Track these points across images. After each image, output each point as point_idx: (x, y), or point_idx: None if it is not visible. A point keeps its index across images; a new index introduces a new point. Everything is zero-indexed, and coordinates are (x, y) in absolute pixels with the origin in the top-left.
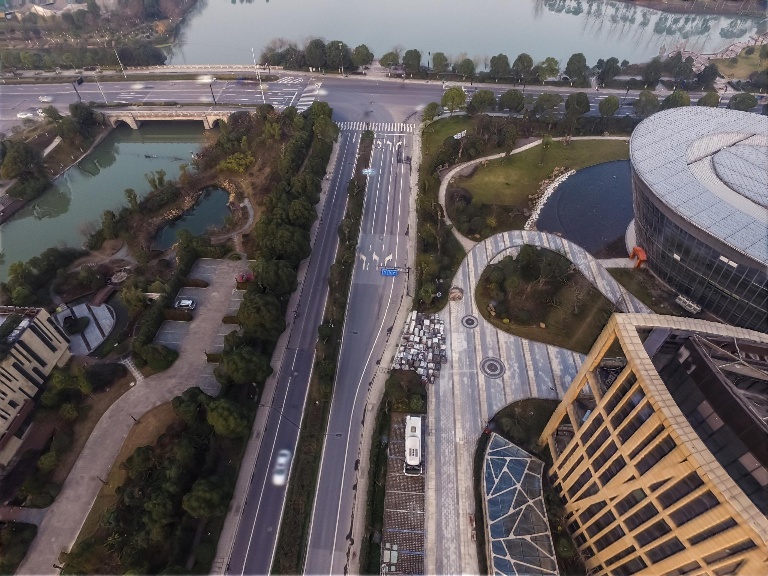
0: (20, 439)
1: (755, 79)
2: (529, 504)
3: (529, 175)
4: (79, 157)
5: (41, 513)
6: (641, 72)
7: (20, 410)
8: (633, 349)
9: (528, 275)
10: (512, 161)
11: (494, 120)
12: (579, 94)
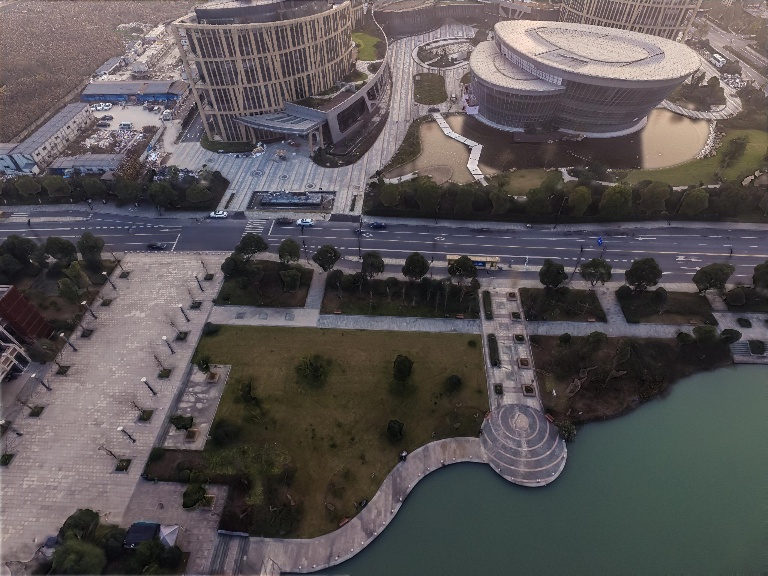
0: None
1: None
2: None
3: None
4: None
5: None
6: None
7: None
8: None
9: None
10: (758, 160)
11: None
12: None
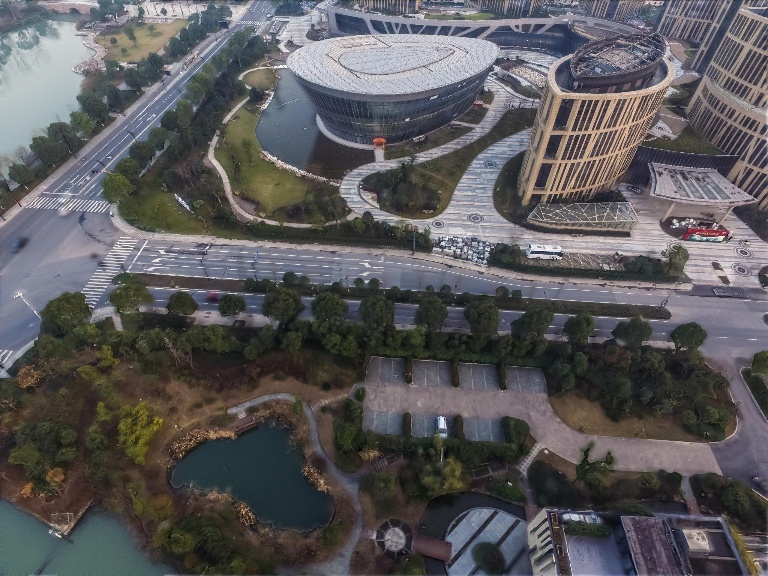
0: None
1: (171, 51)
2: (566, 208)
3: (266, 172)
4: None
5: None
6: (130, 84)
7: None
8: (576, 95)
9: (395, 190)
10: (241, 177)
11: (149, 179)
12: (169, 113)
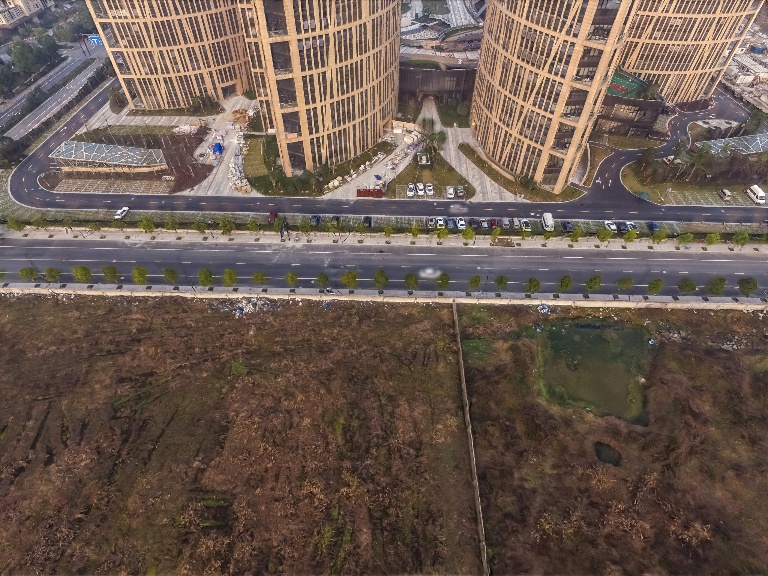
0: (39, 21)
1: None
2: None
3: None
4: None
5: (48, 29)
6: None
7: (39, 10)
8: None
9: None
10: None
11: None
12: None
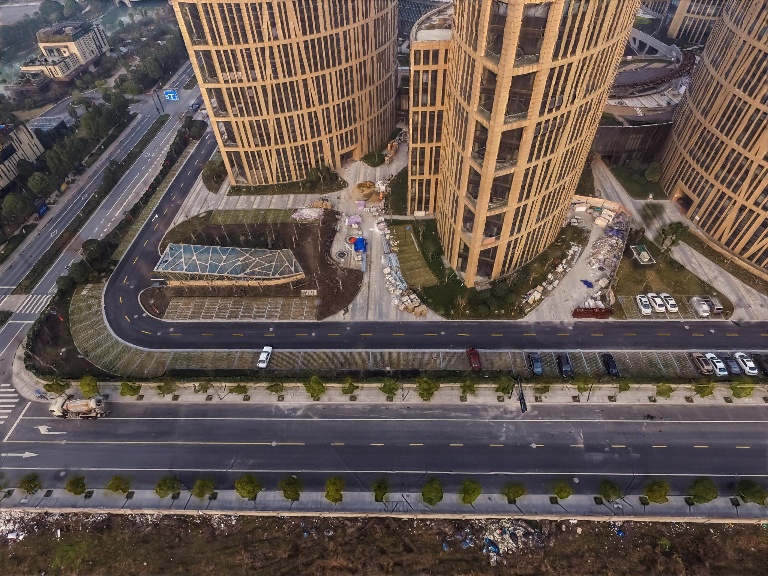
0: (95, 69)
1: None
2: None
3: None
4: (100, 16)
5: (107, 79)
6: None
7: None
8: None
9: None
10: None
11: None
12: None
